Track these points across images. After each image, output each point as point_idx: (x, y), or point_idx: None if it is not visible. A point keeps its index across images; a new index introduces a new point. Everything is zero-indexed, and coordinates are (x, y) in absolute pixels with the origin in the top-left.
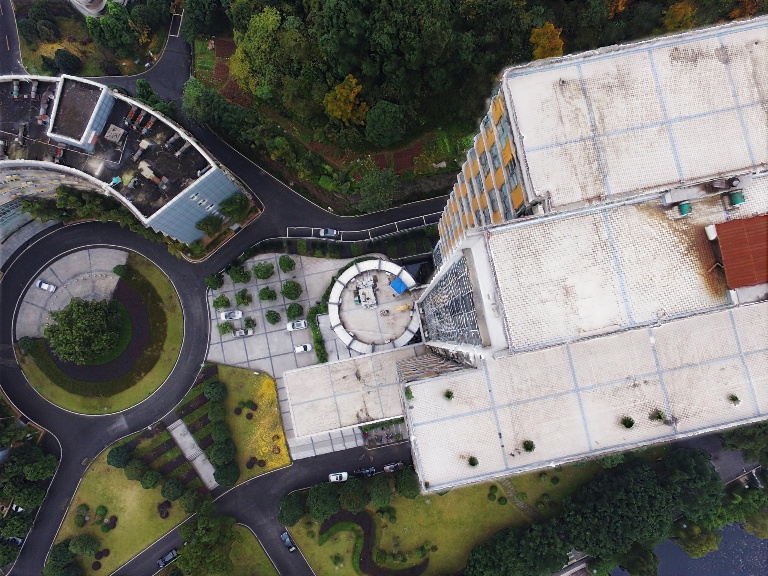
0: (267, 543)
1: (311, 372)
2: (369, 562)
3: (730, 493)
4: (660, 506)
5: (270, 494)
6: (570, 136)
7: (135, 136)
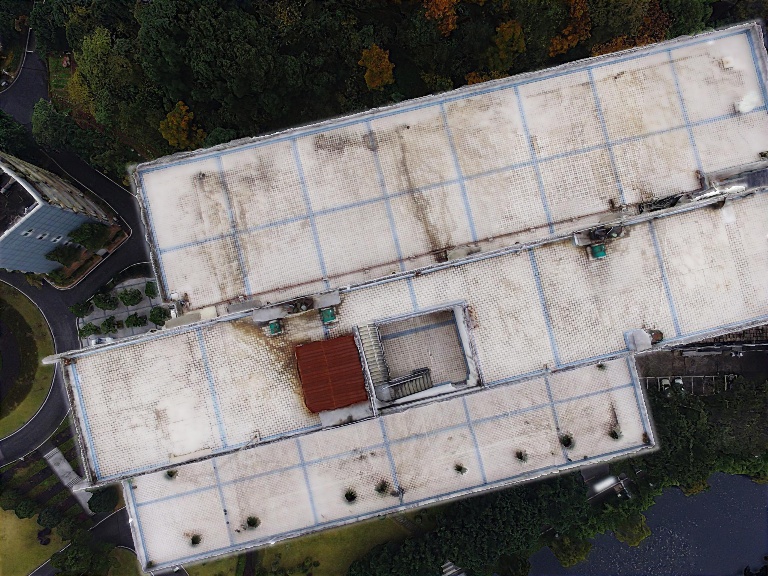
0: None
1: None
2: None
3: (603, 502)
4: (526, 520)
5: None
6: (210, 233)
7: None
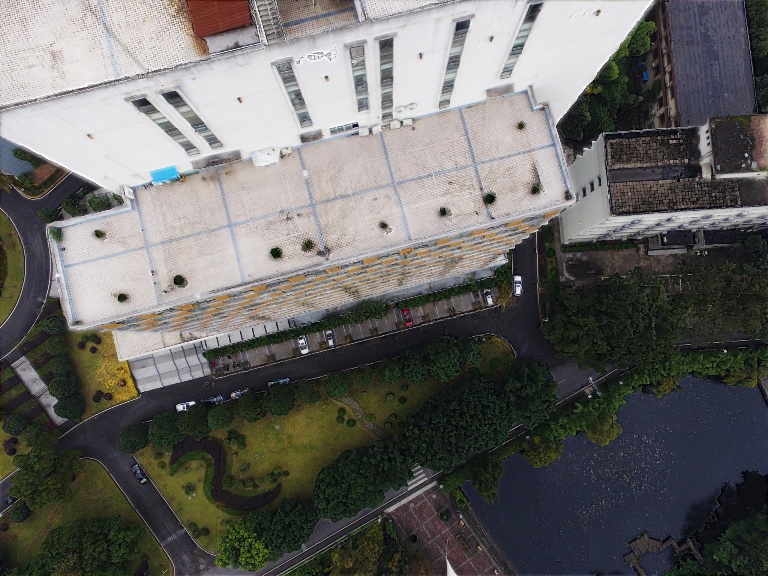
0: (119, 476)
1: None
2: (221, 490)
3: (573, 403)
4: (493, 414)
5: (119, 427)
6: None
7: None
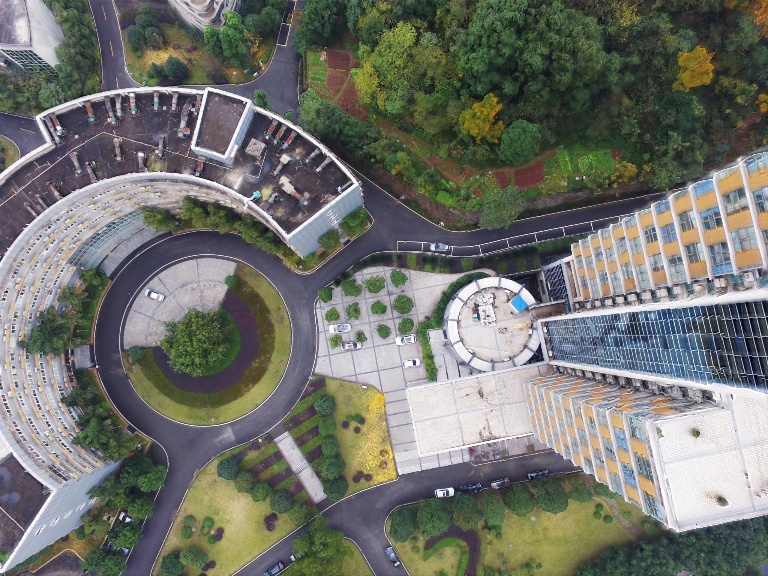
0: (371, 557)
1: (434, 389)
2: None
3: None
4: None
5: (375, 508)
6: None
7: (274, 150)
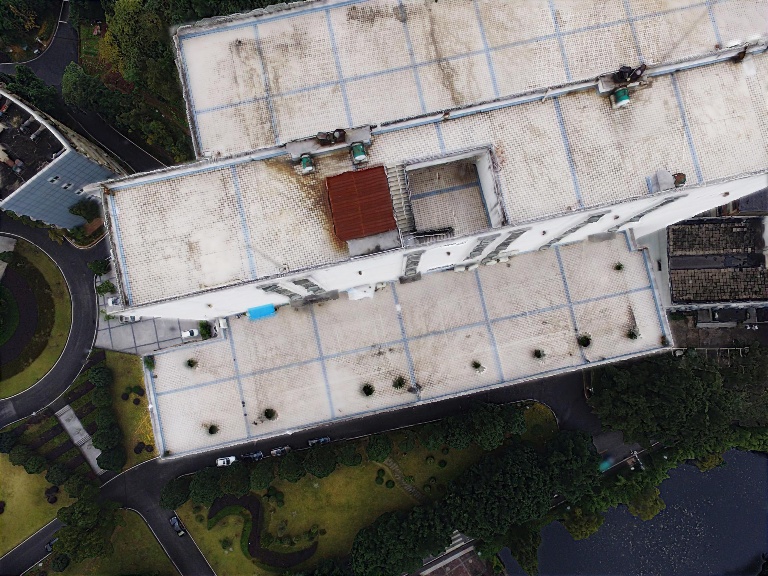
0: (157, 527)
1: None
2: (257, 546)
3: (616, 475)
4: (537, 487)
5: (159, 479)
6: (244, 96)
7: None
